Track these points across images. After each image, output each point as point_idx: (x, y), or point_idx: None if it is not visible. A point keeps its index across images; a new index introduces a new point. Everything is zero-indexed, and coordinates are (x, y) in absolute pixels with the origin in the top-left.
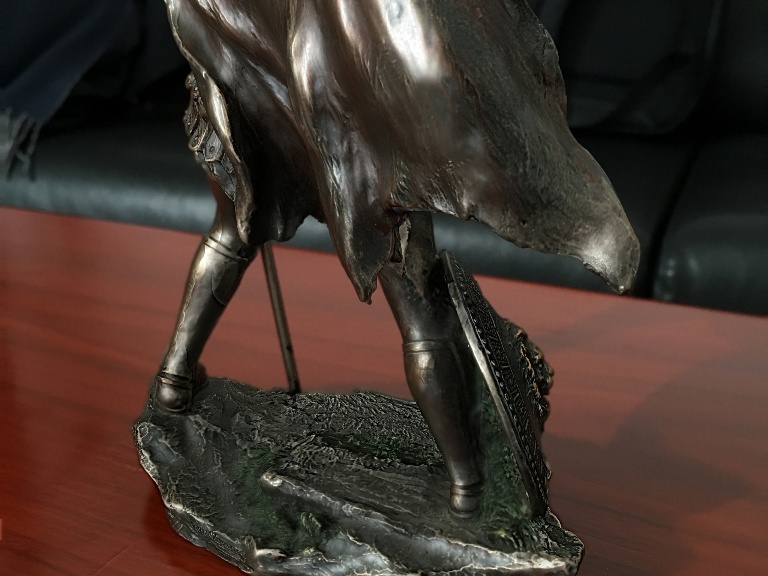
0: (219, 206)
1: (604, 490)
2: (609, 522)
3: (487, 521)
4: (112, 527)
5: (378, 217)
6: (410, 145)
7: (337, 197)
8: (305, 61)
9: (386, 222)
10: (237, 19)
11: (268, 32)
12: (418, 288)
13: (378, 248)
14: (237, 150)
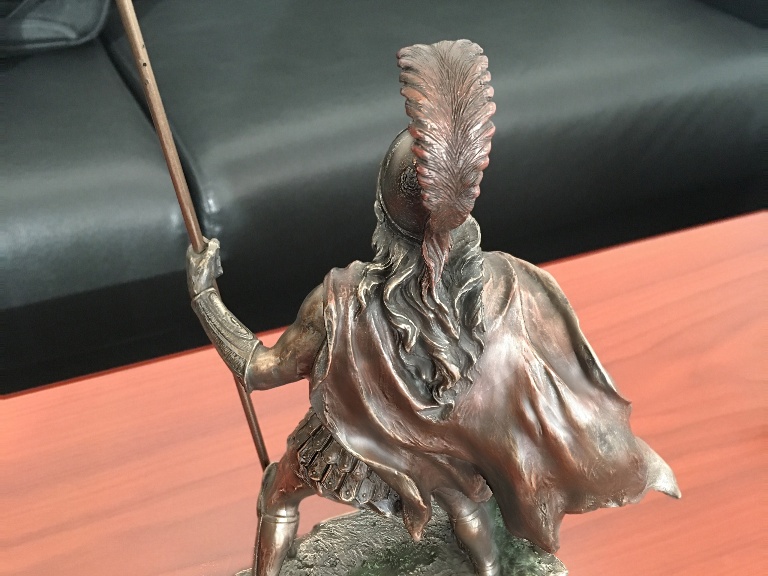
0: None
1: None
2: None
3: (513, 575)
4: None
5: None
6: None
7: (545, 520)
8: (532, 471)
9: None
10: (433, 442)
11: None
12: None
13: None
14: None
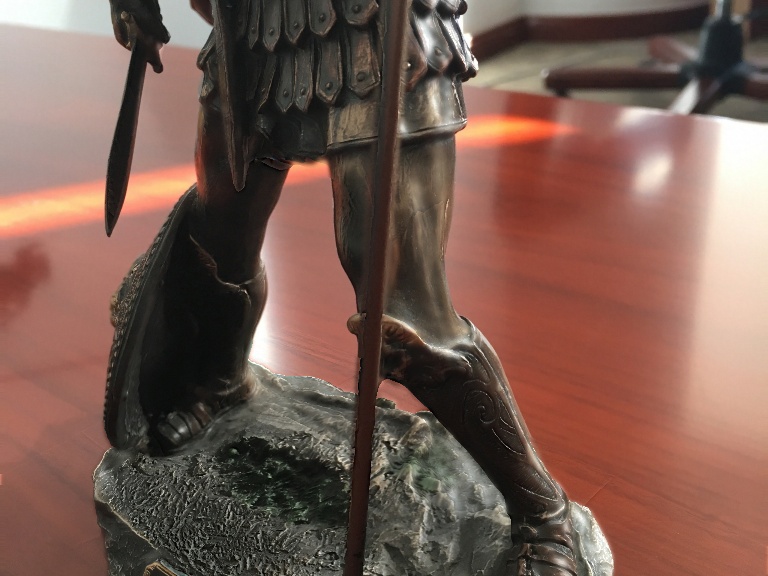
0: None
1: (40, 502)
2: (79, 465)
3: None
4: (612, 536)
5: None
6: None
7: None
8: None
9: None
10: None
11: None
12: None
13: None
14: None
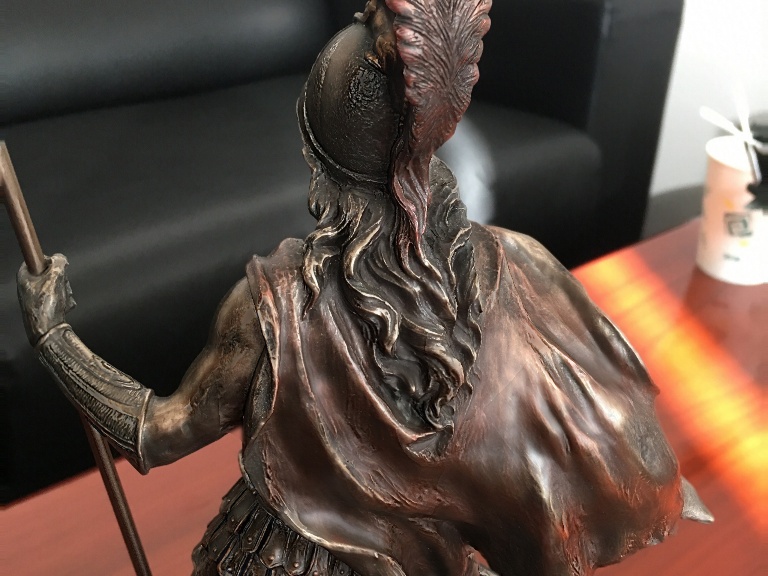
0: None
1: None
2: None
3: None
4: None
5: None
6: (644, 522)
7: None
8: (562, 509)
9: None
10: (423, 496)
11: (456, 492)
12: None
13: None
14: None
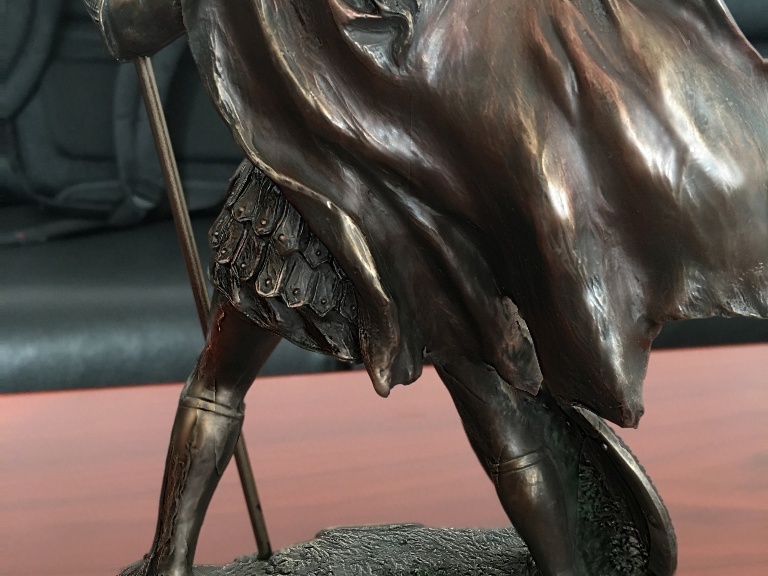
0: (220, 358)
1: None
2: None
3: None
4: None
5: (641, 334)
6: (714, 253)
7: (603, 321)
8: (562, 178)
9: (648, 337)
10: (390, 137)
11: (439, 149)
12: (512, 400)
13: (638, 366)
14: (385, 288)
